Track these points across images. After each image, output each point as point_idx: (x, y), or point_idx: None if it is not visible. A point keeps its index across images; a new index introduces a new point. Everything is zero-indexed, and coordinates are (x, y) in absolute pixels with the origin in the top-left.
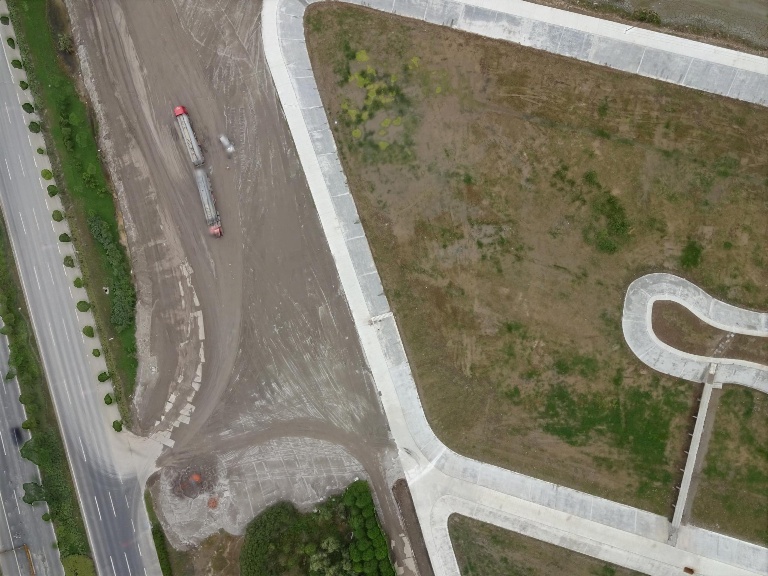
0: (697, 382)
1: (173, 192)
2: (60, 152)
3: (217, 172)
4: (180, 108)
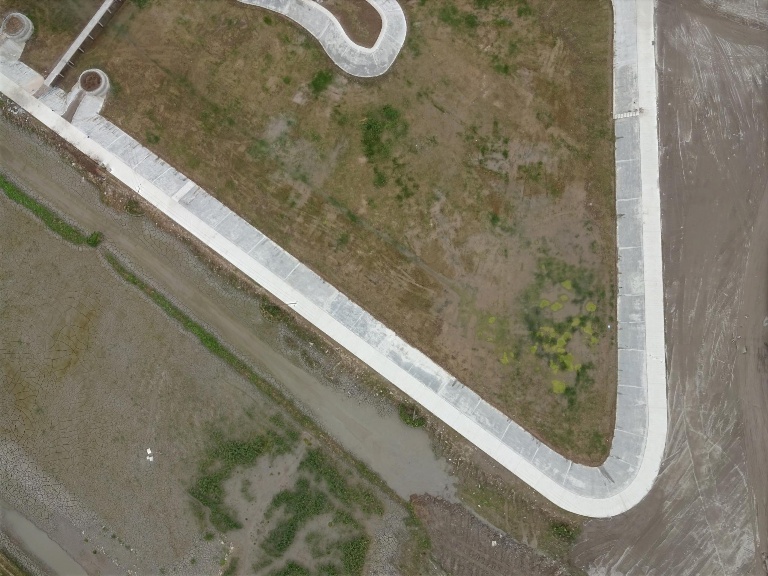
0: None
1: None
2: None
3: (760, 317)
4: None
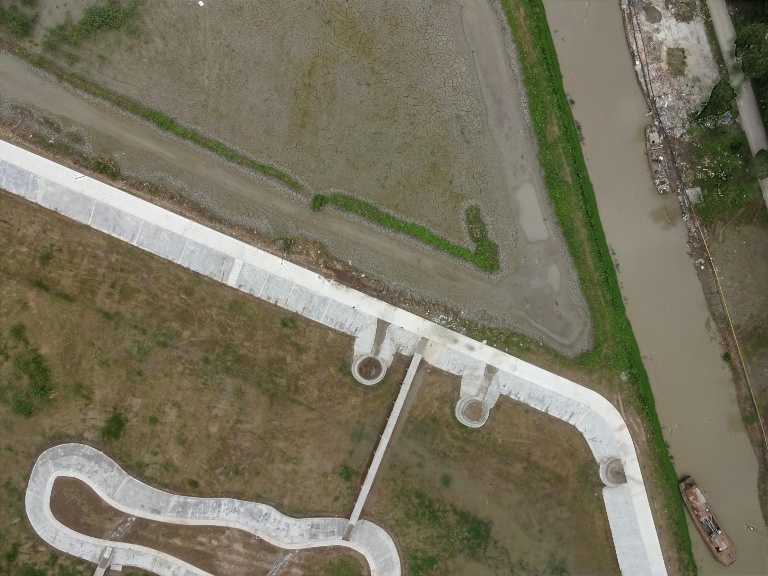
0: (96, 563)
1: None
2: None
3: None
4: None
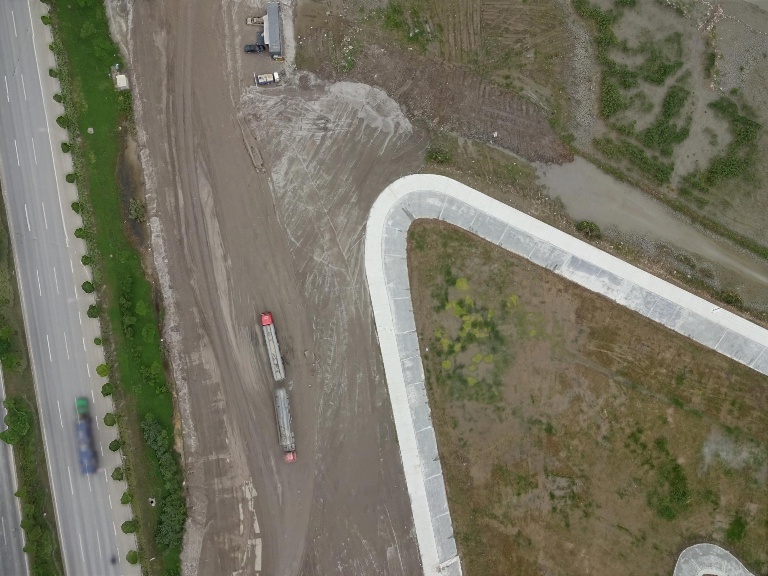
0: None
1: (245, 403)
2: (116, 337)
3: (297, 388)
4: (269, 318)
